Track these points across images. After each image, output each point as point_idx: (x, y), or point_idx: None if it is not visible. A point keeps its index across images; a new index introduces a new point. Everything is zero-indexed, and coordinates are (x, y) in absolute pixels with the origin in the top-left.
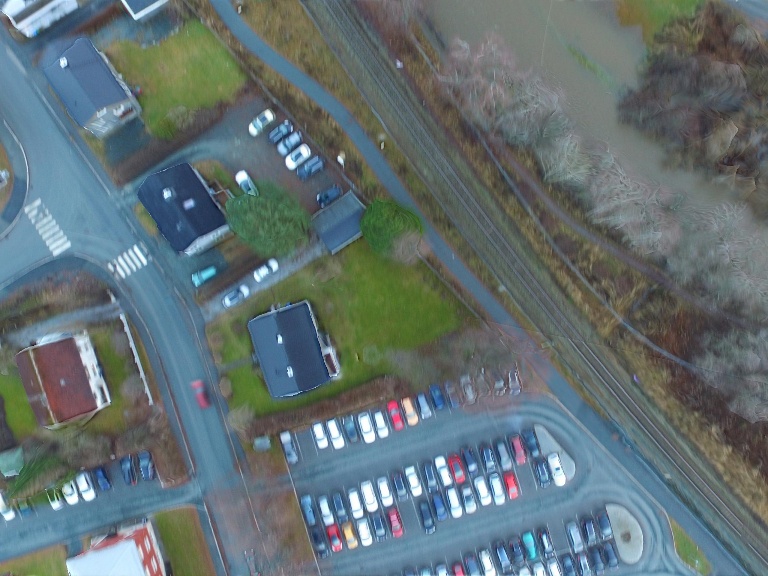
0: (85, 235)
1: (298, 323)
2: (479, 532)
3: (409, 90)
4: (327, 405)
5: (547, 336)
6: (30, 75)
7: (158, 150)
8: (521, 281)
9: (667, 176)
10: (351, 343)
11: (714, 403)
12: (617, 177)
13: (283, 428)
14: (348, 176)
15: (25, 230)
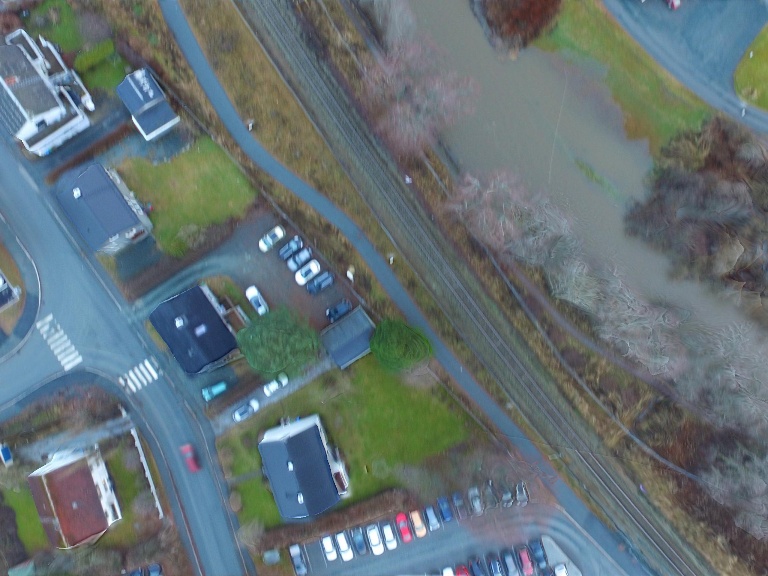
0: (96, 350)
1: (308, 447)
2: None
3: (418, 205)
4: (336, 519)
5: (554, 448)
6: (42, 192)
7: (169, 267)
8: (529, 393)
9: (673, 287)
10: (360, 455)
11: (720, 514)
12: (625, 303)
13: (292, 542)
14: (357, 291)
15: (37, 345)
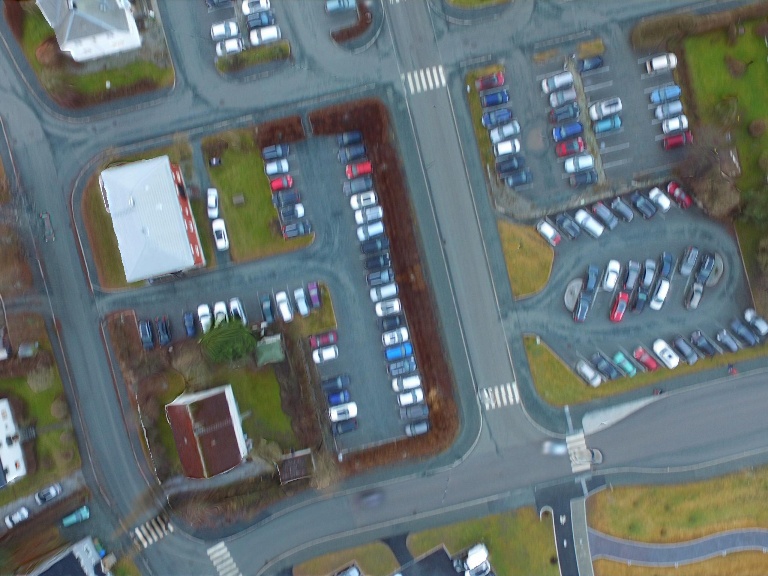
0: (193, 560)
1: None
2: None
3: None
4: None
5: None
6: None
7: None
8: None
9: None
10: None
11: None
12: None
13: (4, 364)
14: None
15: (249, 568)
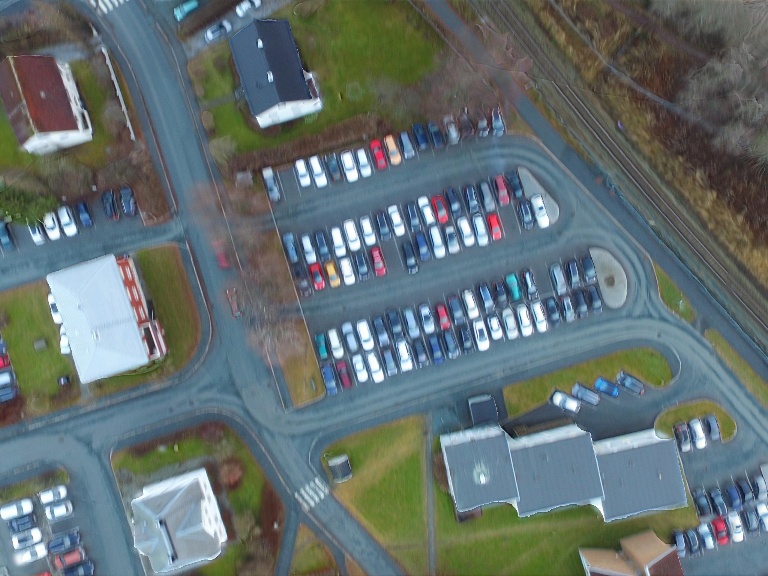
0: None
1: (279, 36)
2: (462, 274)
3: None
4: (309, 139)
5: (531, 78)
6: None
7: None
8: (505, 22)
9: None
10: (334, 83)
11: (698, 147)
12: None
13: (265, 163)
14: None
15: None
